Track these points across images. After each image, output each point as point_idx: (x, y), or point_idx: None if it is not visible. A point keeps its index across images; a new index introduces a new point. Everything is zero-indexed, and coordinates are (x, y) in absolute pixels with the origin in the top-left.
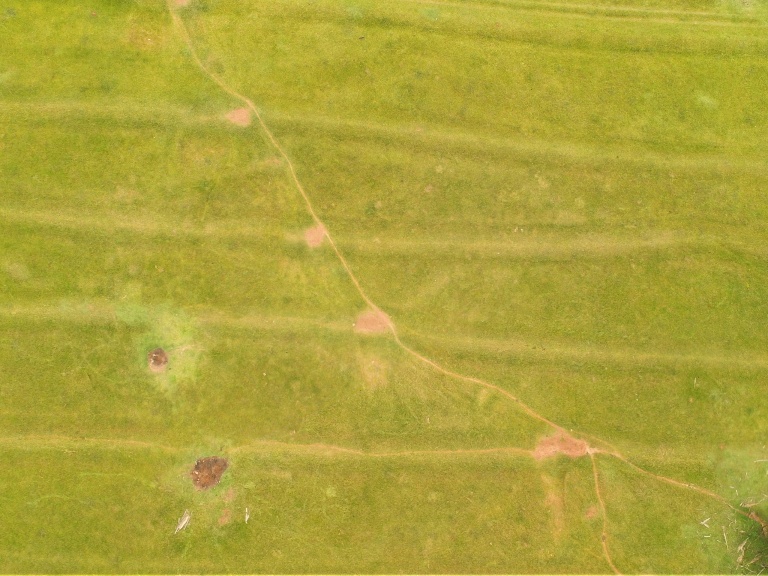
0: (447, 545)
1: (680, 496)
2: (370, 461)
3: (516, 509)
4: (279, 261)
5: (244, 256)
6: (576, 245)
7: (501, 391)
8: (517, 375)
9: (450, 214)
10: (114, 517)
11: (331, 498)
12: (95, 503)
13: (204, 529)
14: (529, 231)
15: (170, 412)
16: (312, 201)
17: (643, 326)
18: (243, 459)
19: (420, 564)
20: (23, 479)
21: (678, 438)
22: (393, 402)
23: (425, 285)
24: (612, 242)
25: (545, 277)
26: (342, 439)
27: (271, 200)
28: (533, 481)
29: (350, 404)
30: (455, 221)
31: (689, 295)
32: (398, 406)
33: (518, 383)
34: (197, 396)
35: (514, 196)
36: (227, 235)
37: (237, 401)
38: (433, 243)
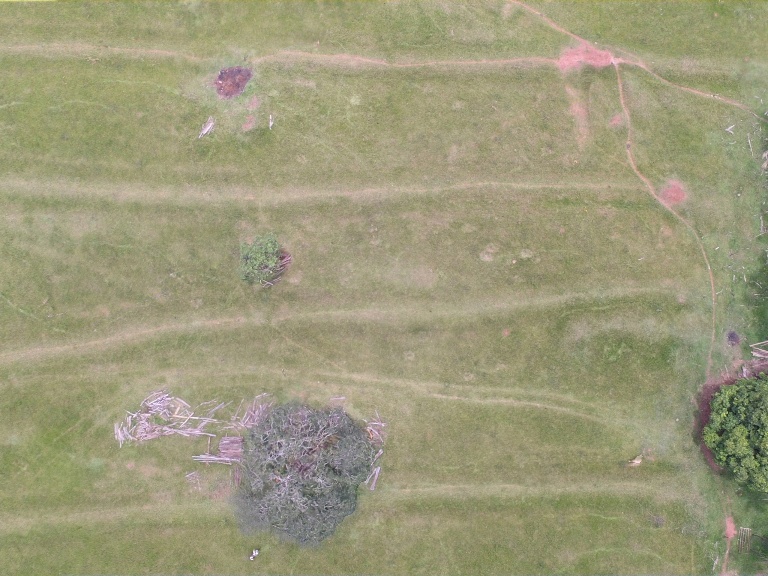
0: (471, 151)
1: (705, 104)
2: (394, 71)
3: (540, 117)
4: None
5: None
6: None
7: (525, 7)
8: None
9: None
10: (138, 123)
11: (355, 106)
12: (119, 109)
13: (228, 135)
14: None
15: (193, 23)
16: None
17: None
18: (267, 69)
19: (444, 170)
20: (46, 85)
21: (703, 51)
22: (417, 15)
23: None
24: None
25: None
26: (366, 51)
27: None
28: (557, 90)
29: (374, 17)
30: None
31: None
32: (422, 18)
33: None
34: (220, 8)
35: None
36: None
37: (261, 14)
38: None
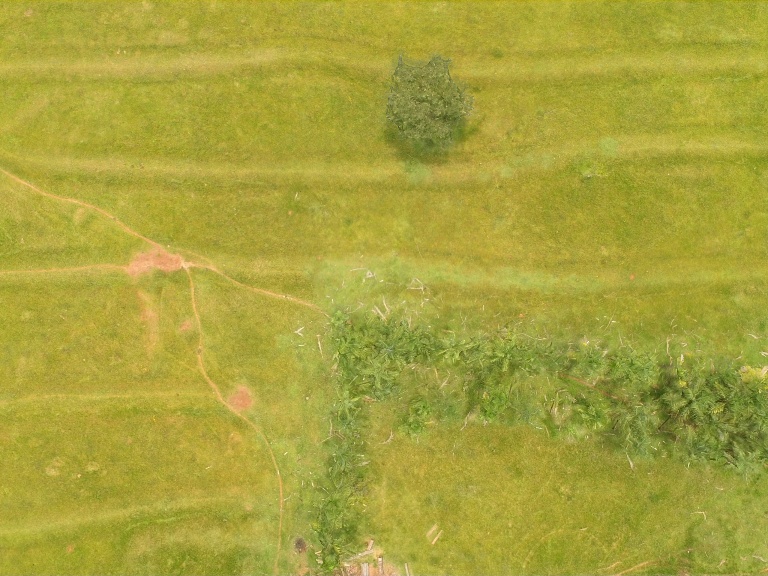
0: (39, 363)
1: (275, 307)
2: None
3: (110, 325)
4: None
5: None
6: (178, 64)
7: (99, 210)
8: (115, 194)
9: (51, 38)
10: None
11: None
12: None
13: None
14: (132, 53)
15: None
16: None
17: (244, 142)
18: None
19: (13, 383)
20: None
21: (276, 251)
22: None
23: (23, 108)
24: (214, 60)
25: (147, 97)
26: None
27: None
28: (127, 297)
29: None
30: (57, 45)
31: (291, 111)
32: None
33: (115, 201)
34: None
35: (116, 18)
36: None
37: None
38: (32, 66)
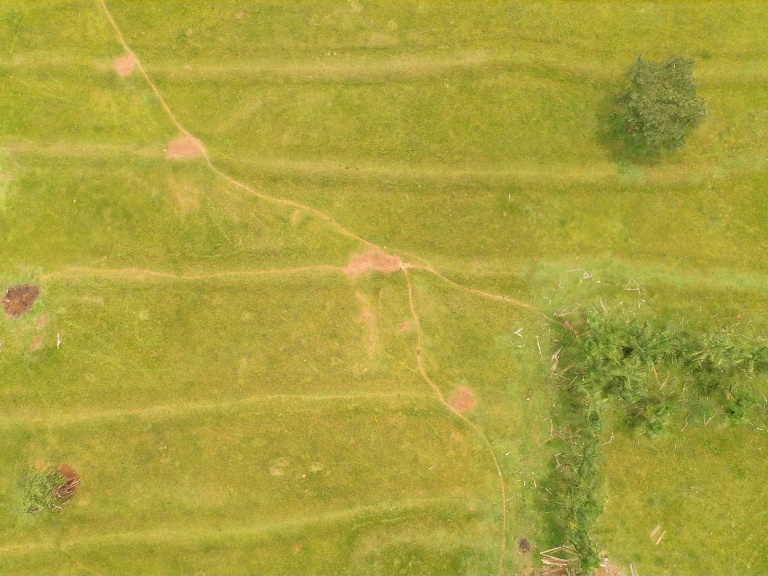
0: (261, 363)
1: (493, 307)
2: (183, 284)
3: (330, 326)
4: (90, 91)
5: (54, 86)
6: (389, 66)
7: (315, 212)
8: (330, 195)
9: (262, 40)
10: None
11: (144, 321)
12: None
13: (16, 355)
14: (342, 54)
15: None
16: (122, 30)
17: (457, 144)
18: (55, 286)
19: (234, 383)
20: None
21: (492, 252)
22: (205, 225)
23: (237, 110)
24: (425, 62)
25: (358, 99)
26: (155, 263)
27: (81, 31)
28: (346, 298)
29: (162, 228)
30: (268, 47)
31: (503, 112)
32: (210, 228)
33: (331, 203)
34: (7, 225)
35: (326, 20)
36: (36, 66)
37: (48, 229)
38: (245, 68)
